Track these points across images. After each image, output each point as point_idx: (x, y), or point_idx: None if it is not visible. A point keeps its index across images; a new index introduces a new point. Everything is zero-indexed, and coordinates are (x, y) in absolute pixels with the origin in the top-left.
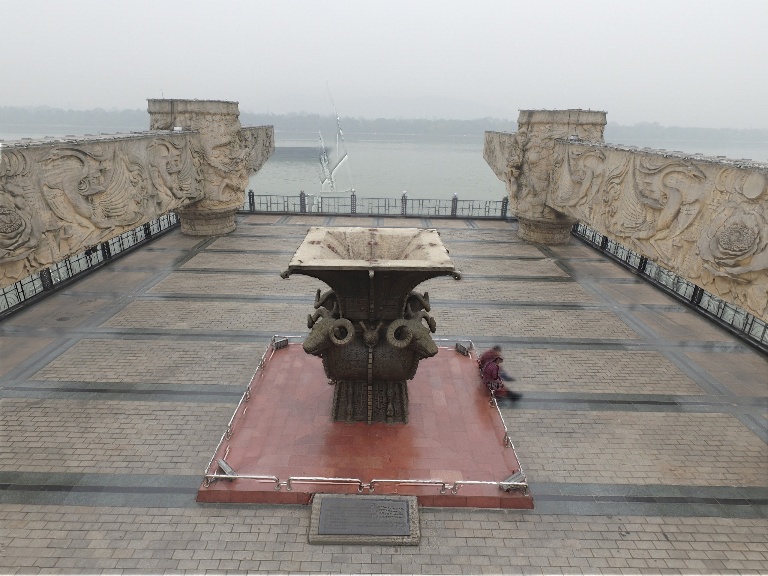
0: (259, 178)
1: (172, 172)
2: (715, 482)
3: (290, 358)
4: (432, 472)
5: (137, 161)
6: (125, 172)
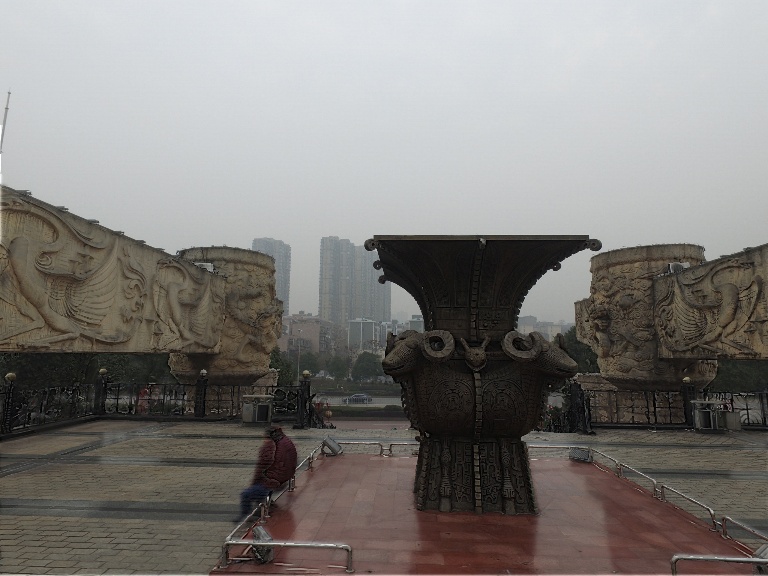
0: None
1: None
2: (135, 466)
3: (692, 548)
4: (397, 460)
5: None
6: None
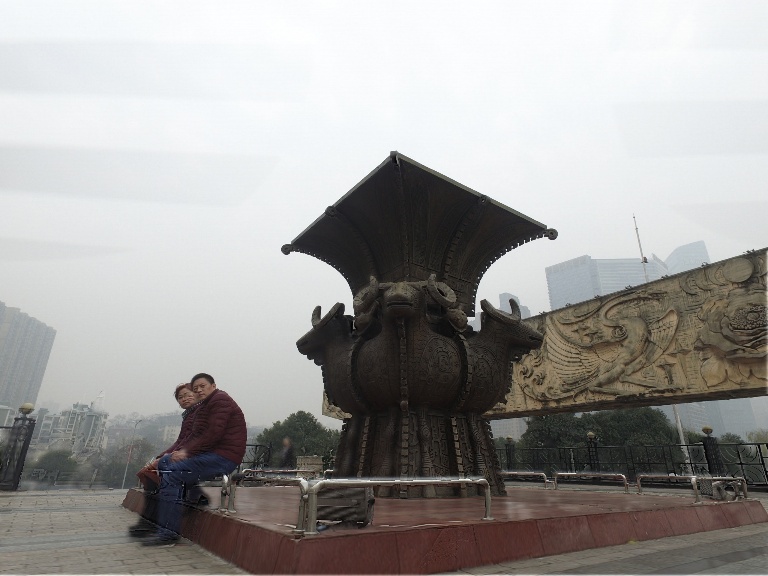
0: None
1: None
2: None
3: None
4: None
5: None
6: None
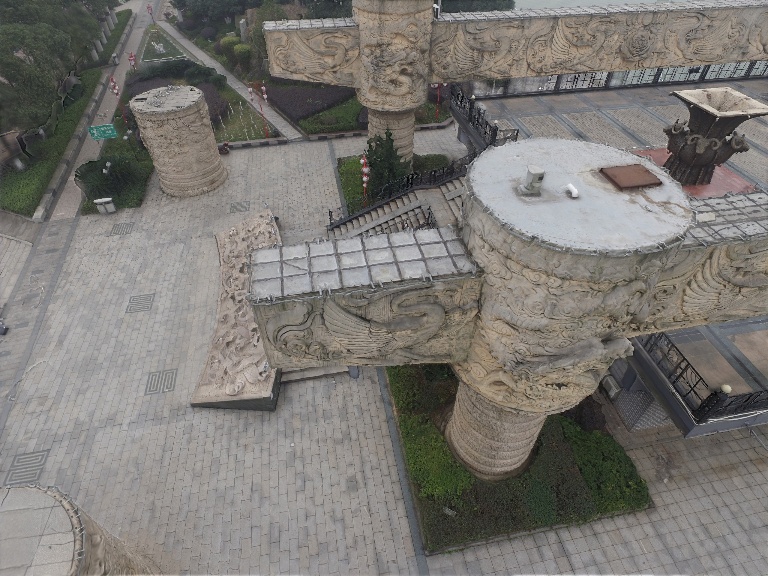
0: None
1: None
2: None
3: None
4: None
5: (743, 22)
6: (728, 28)
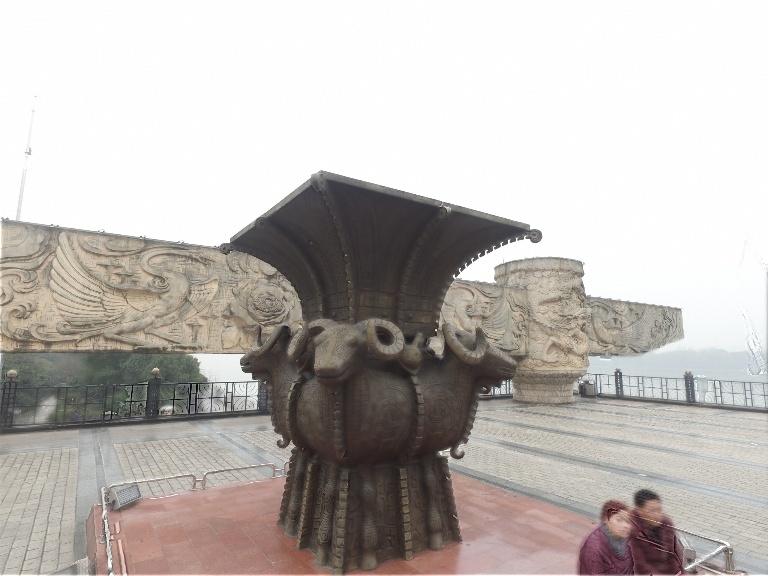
0: (641, 361)
1: (473, 315)
2: None
3: None
4: None
5: None
6: None
